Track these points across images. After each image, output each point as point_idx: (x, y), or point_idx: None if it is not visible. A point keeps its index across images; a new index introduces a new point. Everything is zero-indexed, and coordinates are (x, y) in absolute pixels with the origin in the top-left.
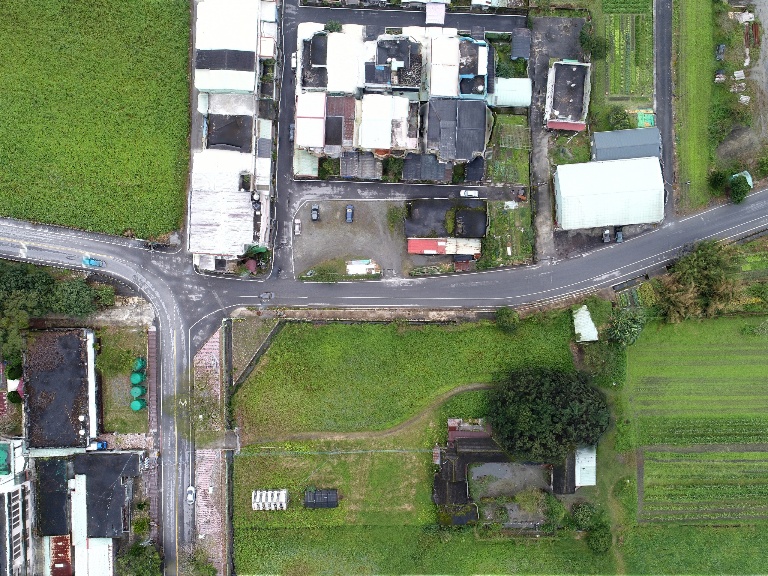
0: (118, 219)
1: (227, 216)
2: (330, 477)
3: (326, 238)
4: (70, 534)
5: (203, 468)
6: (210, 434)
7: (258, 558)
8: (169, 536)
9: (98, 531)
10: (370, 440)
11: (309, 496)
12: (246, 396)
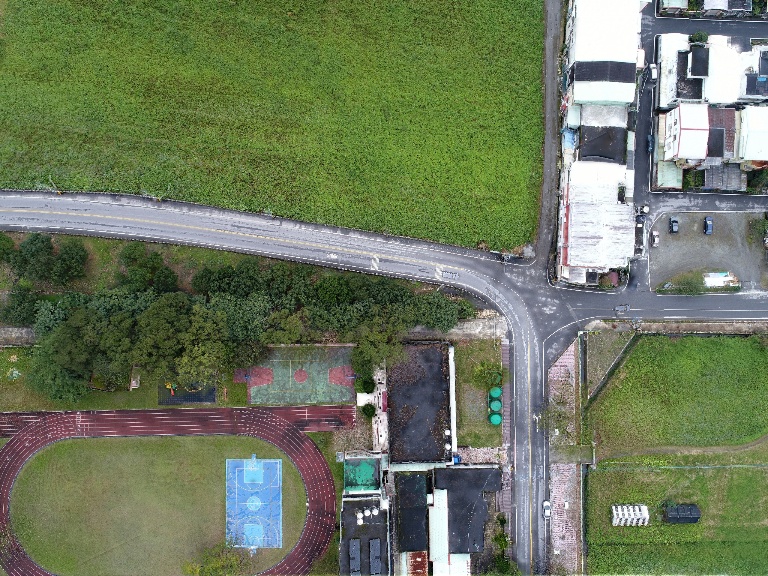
0: (471, 231)
1: (610, 229)
2: (687, 492)
3: (683, 250)
4: (427, 550)
5: (558, 483)
6: (565, 448)
7: (615, 574)
8: (523, 552)
9: (459, 547)
10: (728, 455)
11: (672, 511)
12: (602, 410)
